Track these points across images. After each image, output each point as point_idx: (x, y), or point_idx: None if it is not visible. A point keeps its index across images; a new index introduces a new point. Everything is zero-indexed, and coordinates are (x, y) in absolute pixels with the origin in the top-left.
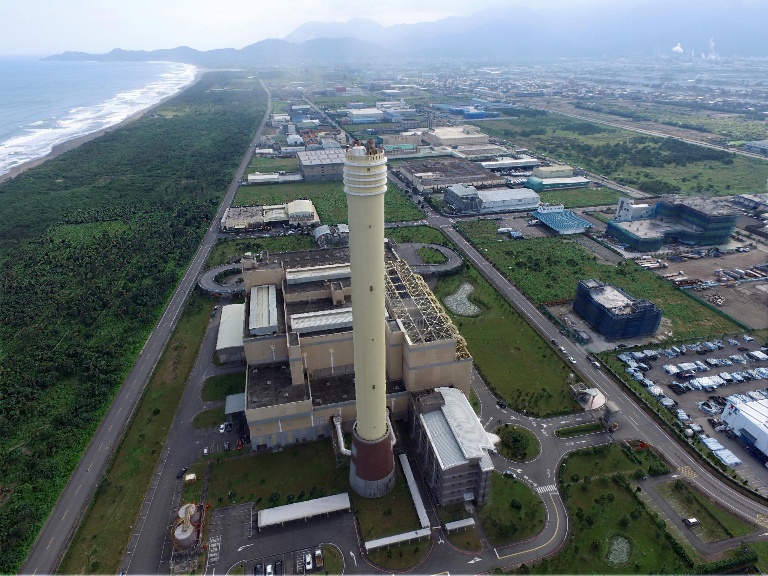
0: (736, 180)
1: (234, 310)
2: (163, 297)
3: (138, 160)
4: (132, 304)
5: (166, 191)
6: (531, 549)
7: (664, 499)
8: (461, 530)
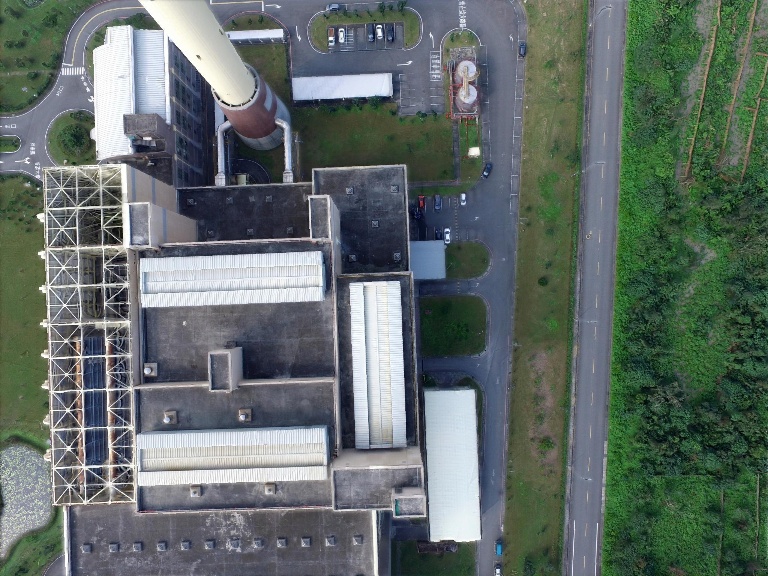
0: None
1: (457, 516)
2: None
3: None
4: None
5: None
6: (123, 9)
7: None
8: None
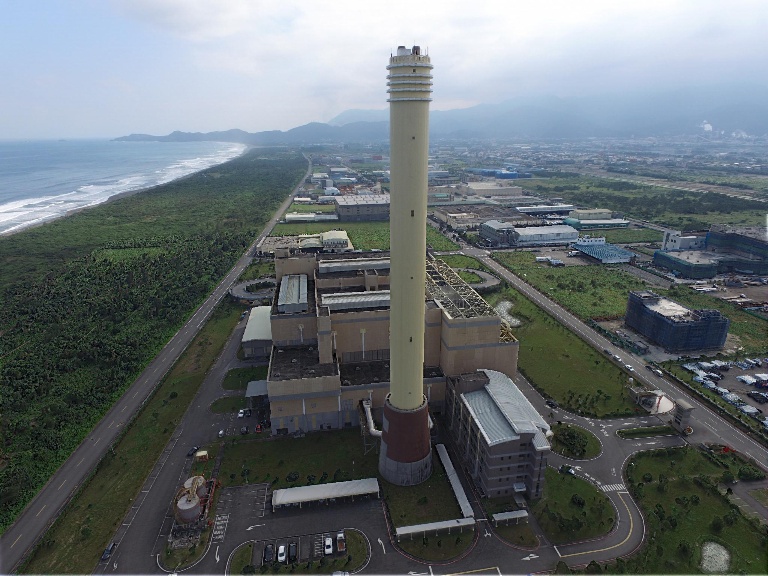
0: None
1: (263, 310)
2: (193, 303)
3: (184, 205)
4: (162, 305)
5: (207, 226)
6: (600, 549)
7: (763, 505)
8: (512, 523)
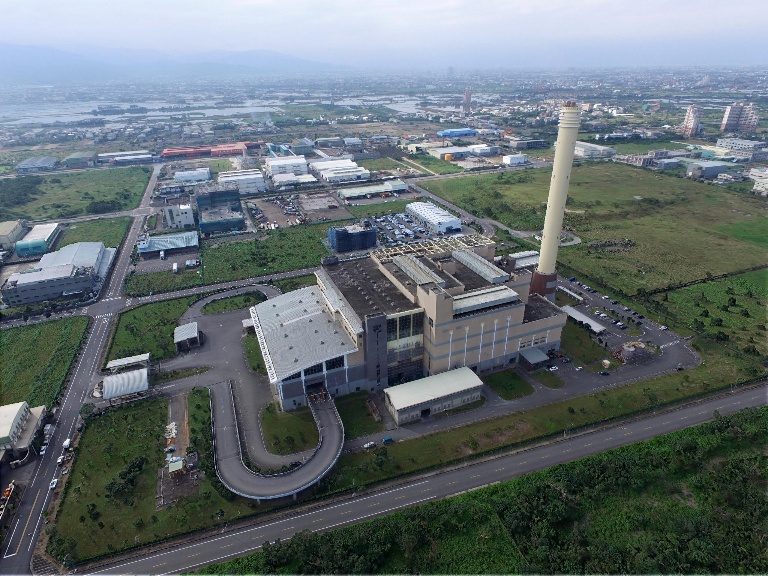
0: (109, 186)
1: (406, 393)
2: None
3: None
4: None
5: None
6: None
7: None
8: None
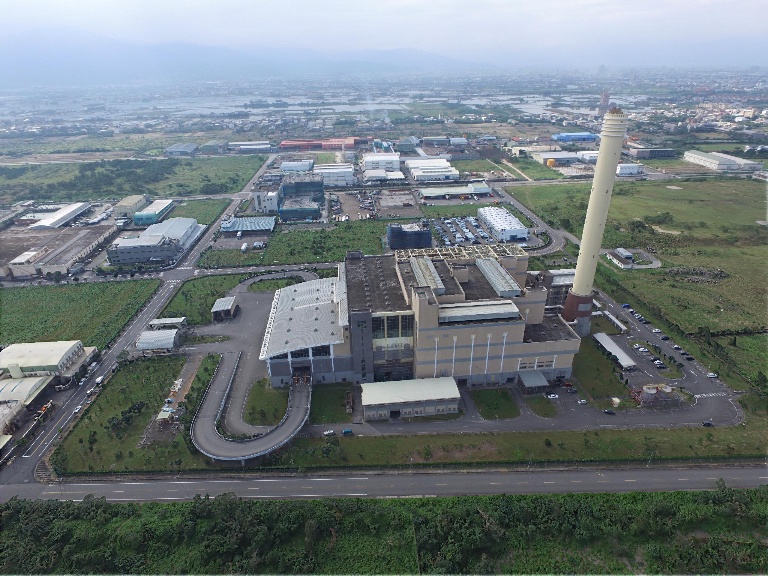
0: (226, 171)
1: (379, 392)
2: None
3: None
4: None
5: None
6: None
7: None
8: None
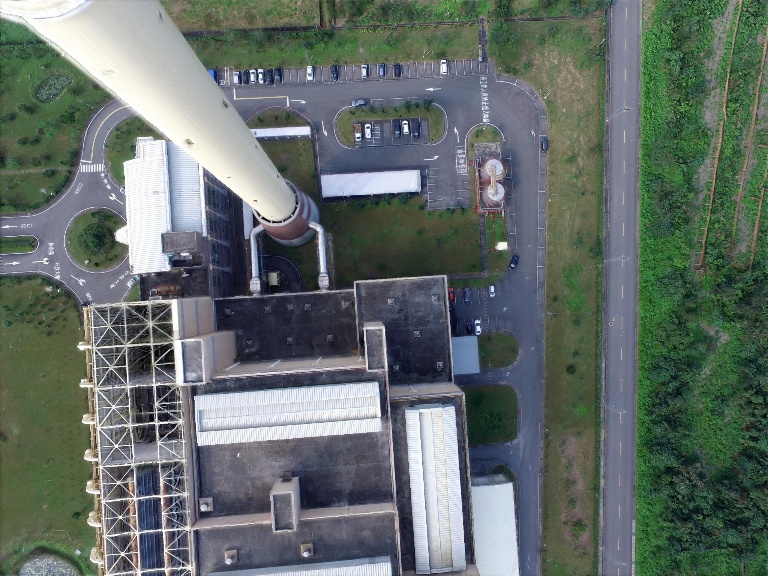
0: None
1: None
2: None
3: None
4: None
5: None
6: None
7: None
8: None
